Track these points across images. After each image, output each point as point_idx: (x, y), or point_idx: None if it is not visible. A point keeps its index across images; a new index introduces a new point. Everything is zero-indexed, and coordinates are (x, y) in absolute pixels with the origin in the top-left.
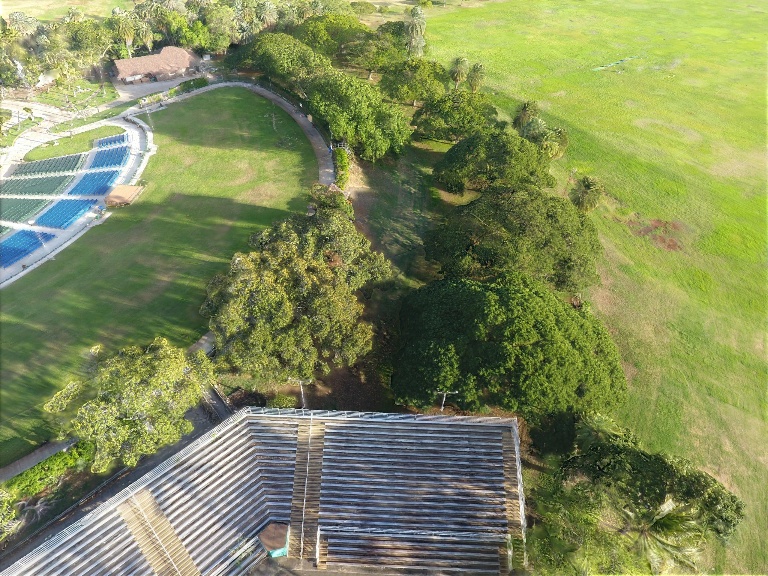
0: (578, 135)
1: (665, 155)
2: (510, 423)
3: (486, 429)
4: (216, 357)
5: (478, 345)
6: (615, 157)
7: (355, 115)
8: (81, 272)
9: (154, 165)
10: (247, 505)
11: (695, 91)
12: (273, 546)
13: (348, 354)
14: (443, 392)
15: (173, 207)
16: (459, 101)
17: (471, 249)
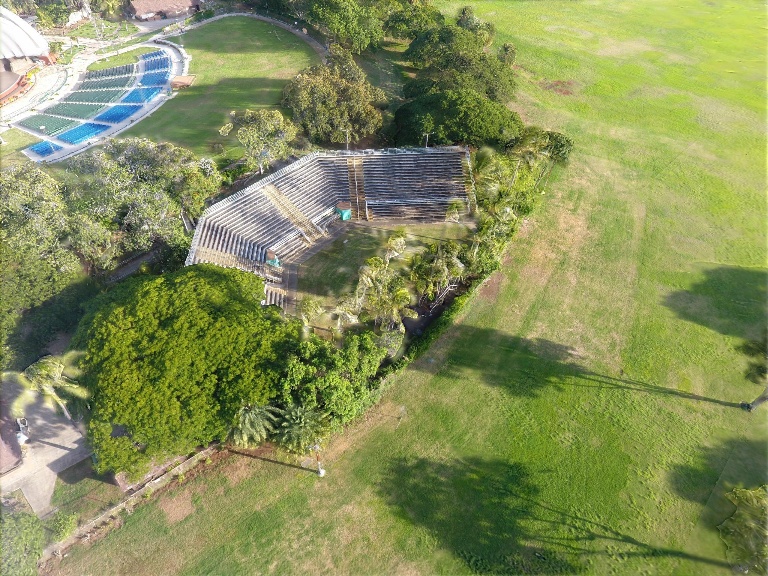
0: (505, 38)
1: (566, 46)
2: (464, 151)
3: (451, 154)
4: (297, 123)
5: (443, 111)
6: (531, 49)
7: (344, 17)
8: (175, 119)
9: (195, 66)
10: (326, 196)
11: (592, 8)
12: (344, 209)
13: (370, 125)
14: (426, 134)
15: (223, 85)
16: (416, 11)
17: (434, 86)
